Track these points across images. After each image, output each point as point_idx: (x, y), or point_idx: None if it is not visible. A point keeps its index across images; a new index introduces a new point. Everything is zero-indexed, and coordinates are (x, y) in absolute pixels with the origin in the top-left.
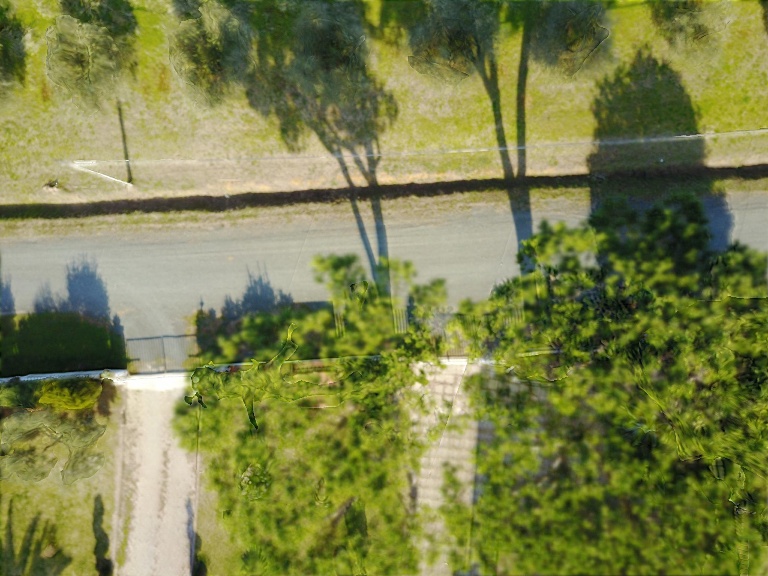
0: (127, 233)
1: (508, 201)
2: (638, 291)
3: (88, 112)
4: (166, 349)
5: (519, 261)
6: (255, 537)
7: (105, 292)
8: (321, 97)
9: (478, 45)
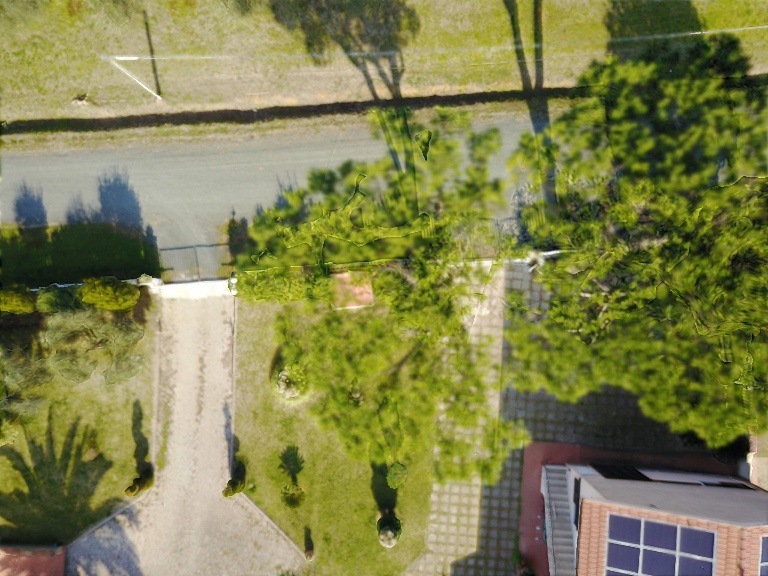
0: (158, 145)
1: (527, 110)
2: (651, 193)
3: (120, 21)
4: (199, 258)
5: (539, 167)
6: (291, 436)
7: (137, 203)
8: (346, 11)
9: None
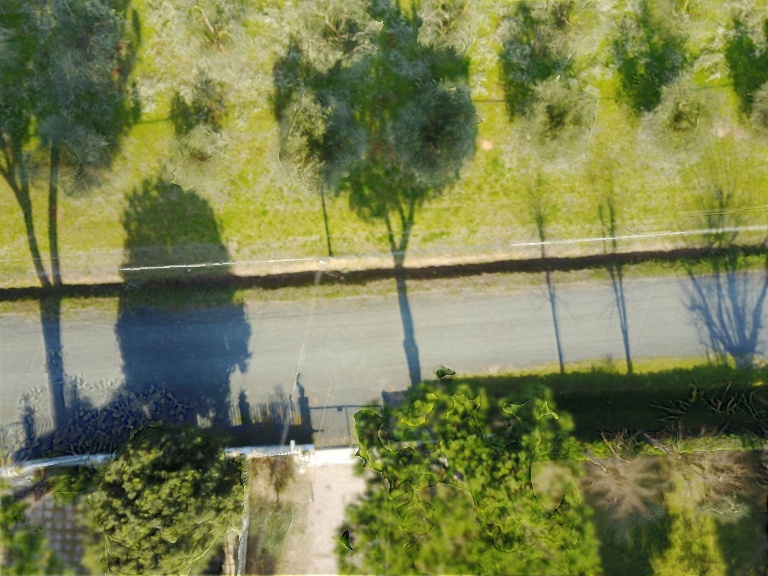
0: None
1: (38, 311)
2: (161, 398)
3: None
4: None
5: (47, 370)
6: None
7: None
8: None
9: (7, 158)
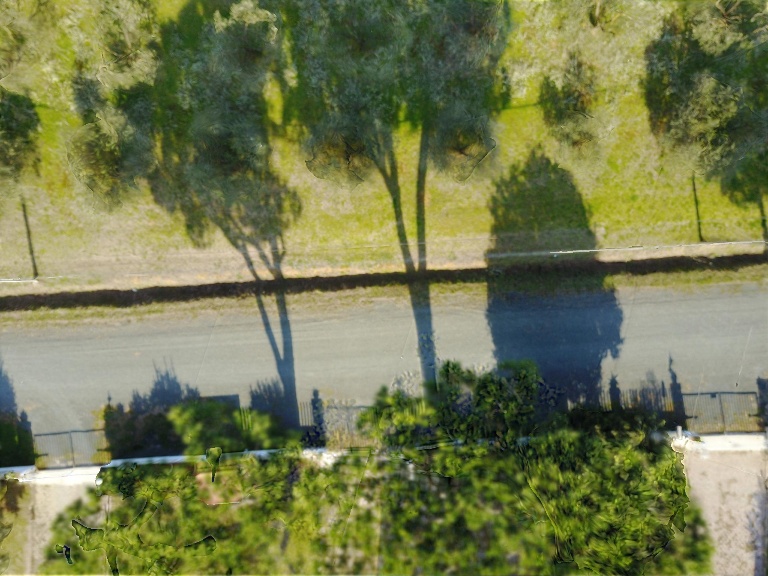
0: (33, 330)
1: (409, 296)
2: (532, 383)
3: None
4: (74, 444)
5: (419, 355)
6: None
7: (11, 389)
8: None
9: (378, 144)
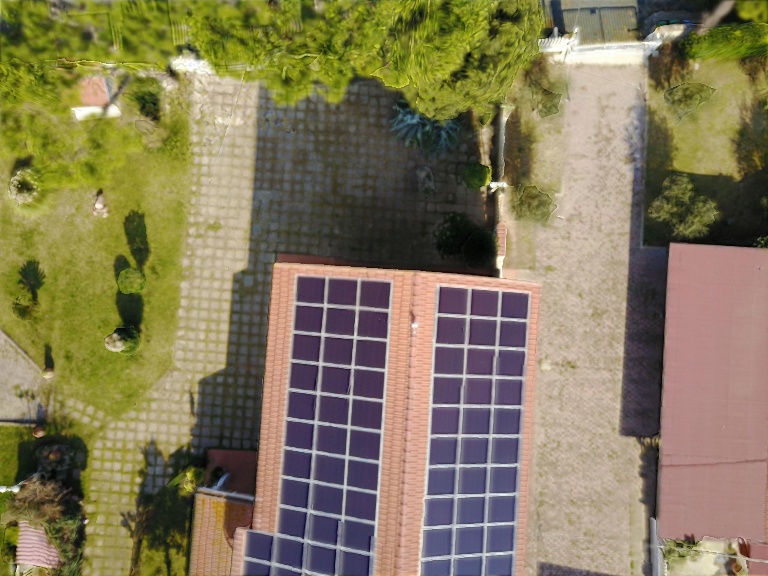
0: None
1: None
2: None
3: None
4: None
5: None
6: (32, 250)
7: None
8: None
9: None
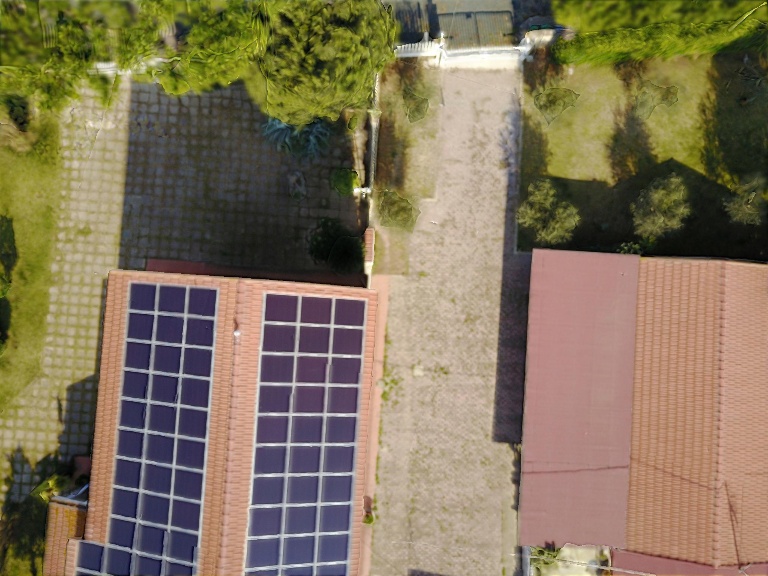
0: None
1: None
2: None
3: None
4: None
5: None
6: None
7: None
8: None
9: None
